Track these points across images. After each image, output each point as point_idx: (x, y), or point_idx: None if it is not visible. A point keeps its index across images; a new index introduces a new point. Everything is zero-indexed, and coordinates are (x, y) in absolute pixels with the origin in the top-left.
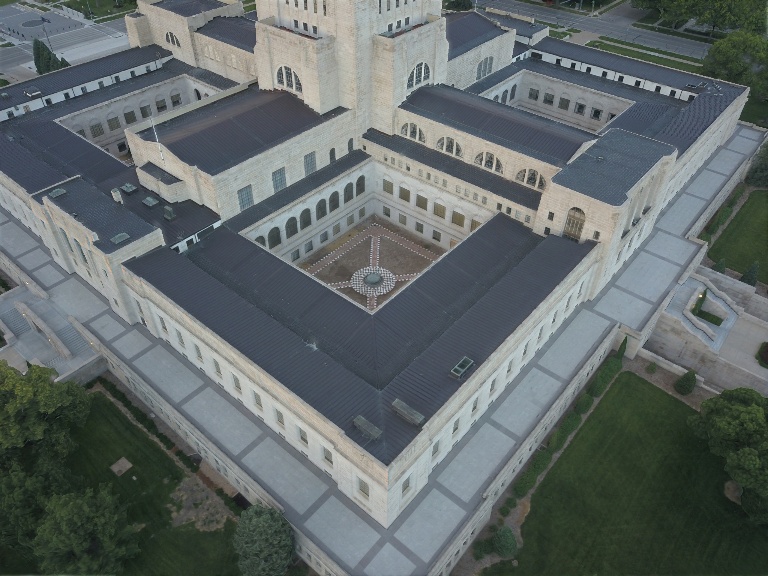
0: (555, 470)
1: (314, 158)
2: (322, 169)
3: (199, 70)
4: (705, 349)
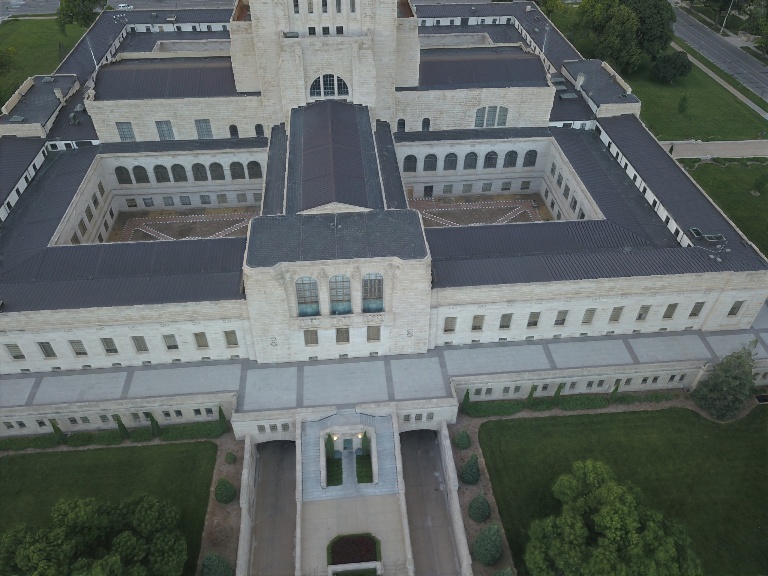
0: (45, 455)
1: (210, 126)
2: (219, 139)
3: None
4: None
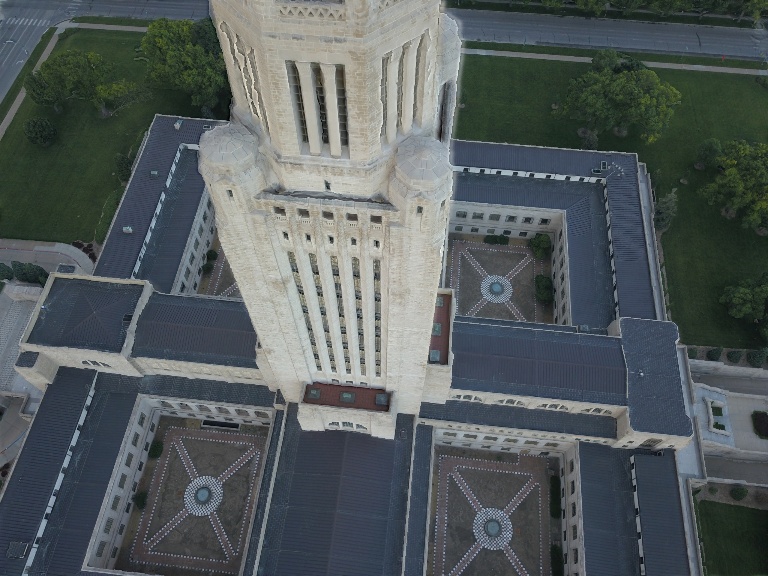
0: None
1: None
2: None
3: (148, 378)
4: (731, 450)
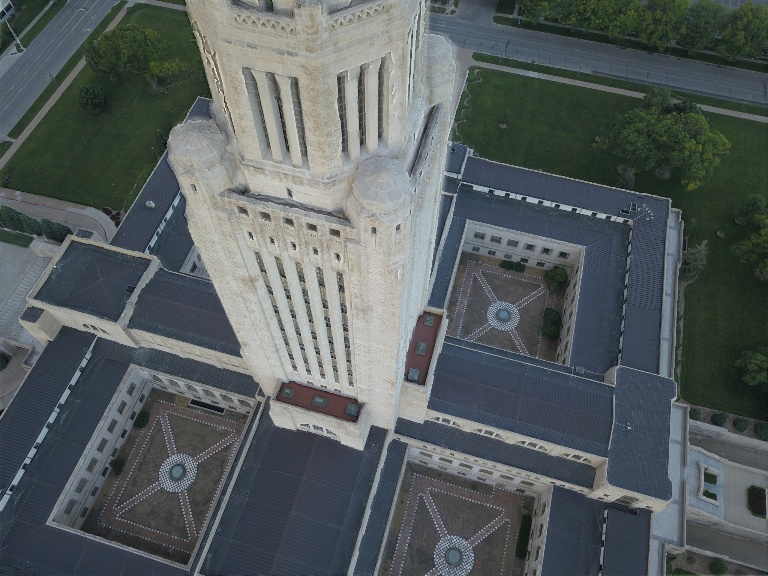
0: None
1: None
2: (377, 489)
3: (143, 350)
4: None
